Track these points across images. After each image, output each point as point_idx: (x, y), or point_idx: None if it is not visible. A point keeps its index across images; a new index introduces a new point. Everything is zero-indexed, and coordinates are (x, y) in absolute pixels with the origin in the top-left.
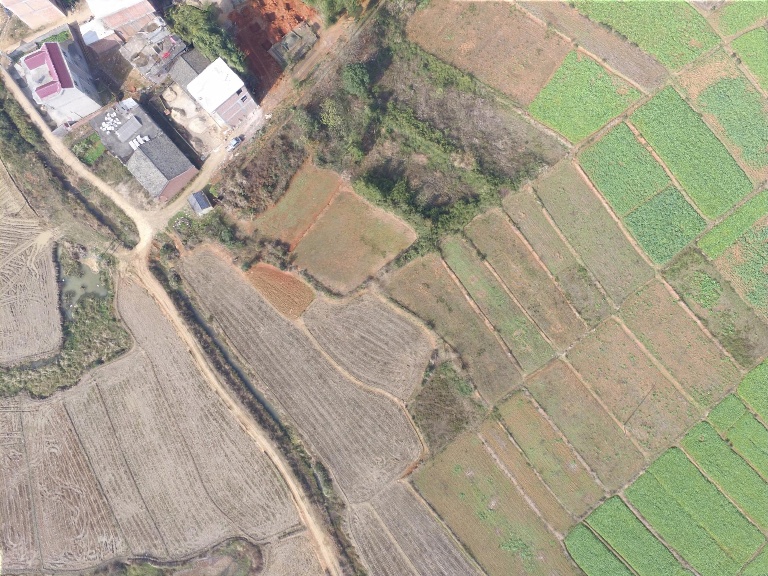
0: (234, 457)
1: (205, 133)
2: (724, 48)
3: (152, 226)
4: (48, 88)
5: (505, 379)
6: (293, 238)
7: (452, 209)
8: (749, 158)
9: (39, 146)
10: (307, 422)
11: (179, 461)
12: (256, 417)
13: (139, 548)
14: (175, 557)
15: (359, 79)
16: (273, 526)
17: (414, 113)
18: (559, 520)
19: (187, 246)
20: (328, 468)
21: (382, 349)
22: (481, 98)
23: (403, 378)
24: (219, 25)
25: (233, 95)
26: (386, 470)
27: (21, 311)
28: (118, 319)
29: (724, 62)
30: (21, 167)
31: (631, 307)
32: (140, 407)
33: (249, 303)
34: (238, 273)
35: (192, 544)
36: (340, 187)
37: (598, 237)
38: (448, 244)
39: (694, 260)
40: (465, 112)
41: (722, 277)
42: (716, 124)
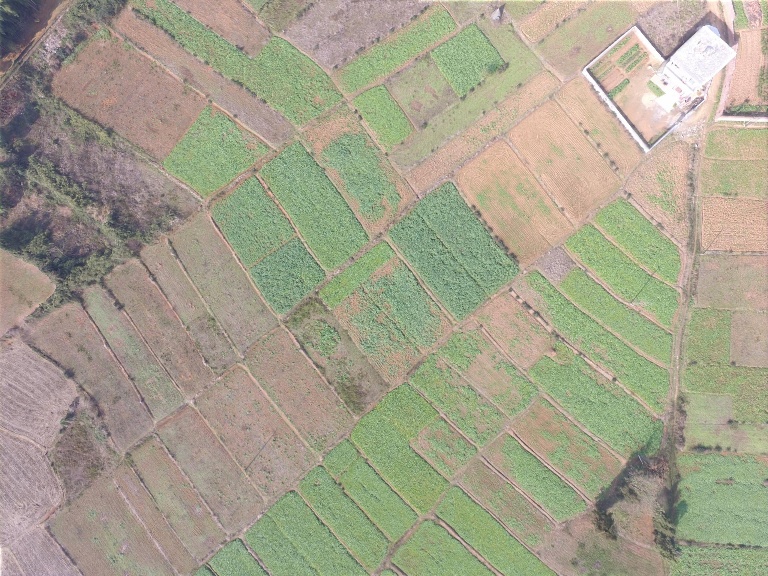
0: None
1: None
2: (348, 105)
3: None
4: None
5: (138, 426)
6: None
7: (87, 261)
8: (365, 211)
9: None
10: None
11: None
12: None
13: None
14: None
15: None
16: None
17: (57, 166)
18: (183, 563)
19: None
20: None
21: (28, 397)
22: (121, 152)
23: (46, 425)
24: None
25: None
26: (27, 516)
27: None
28: None
29: (348, 118)
30: None
31: (257, 355)
32: None
33: None
34: None
35: None
36: None
37: (227, 287)
38: (90, 294)
39: (316, 310)
40: (105, 166)
41: (341, 326)
42: (337, 178)
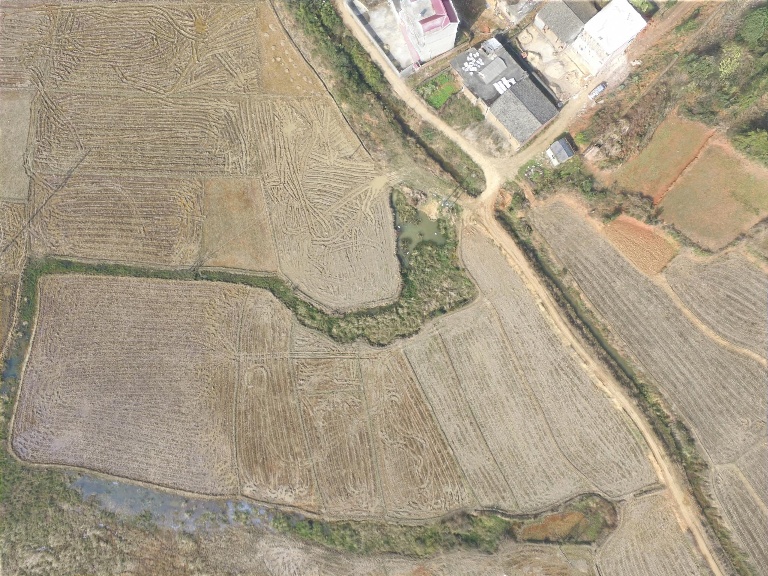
0: (587, 413)
1: (563, 79)
2: None
3: (501, 174)
4: (434, 22)
5: None
6: (656, 191)
7: None
8: None
9: (384, 86)
10: (667, 380)
11: (527, 415)
12: (614, 373)
13: (487, 500)
14: (525, 510)
15: (767, 24)
16: (629, 484)
17: None
18: None
19: (540, 196)
20: (690, 428)
21: (749, 309)
22: None
23: None
24: None
25: (633, 36)
26: (752, 432)
27: (357, 256)
28: (462, 268)
29: None
30: (359, 108)
31: None
32: (486, 359)
33: (604, 257)
34: (592, 226)
35: (543, 498)
36: (710, 140)
37: None
38: None
39: None
40: None
41: None
42: None
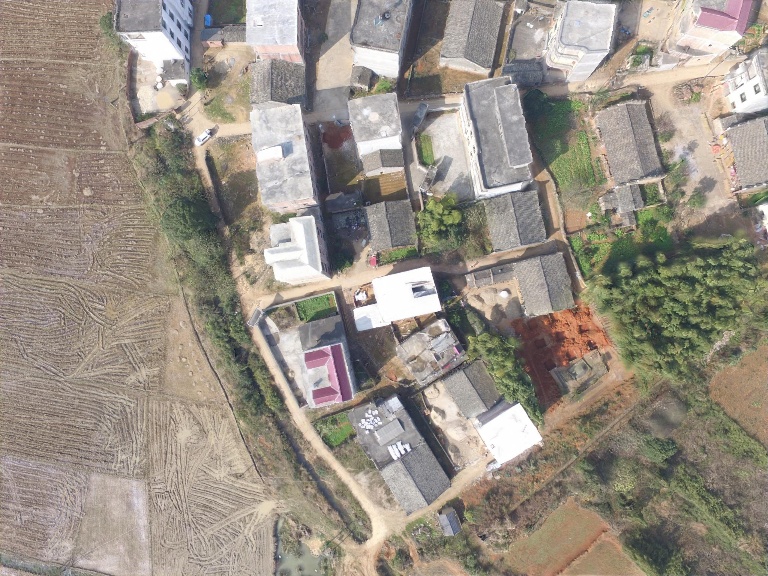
0: None
1: (464, 442)
2: None
3: (388, 526)
4: (327, 397)
5: None
6: None
7: None
8: None
9: (282, 416)
10: None
11: None
12: None
13: None
14: None
15: None
16: None
17: (704, 481)
18: None
19: (424, 559)
20: None
21: None
22: None
23: None
24: (500, 330)
25: None
26: None
27: None
28: None
29: None
30: (256, 430)
31: None
32: None
33: None
34: None
35: None
36: (603, 535)
37: None
38: None
39: None
40: (760, 491)
41: None
42: None
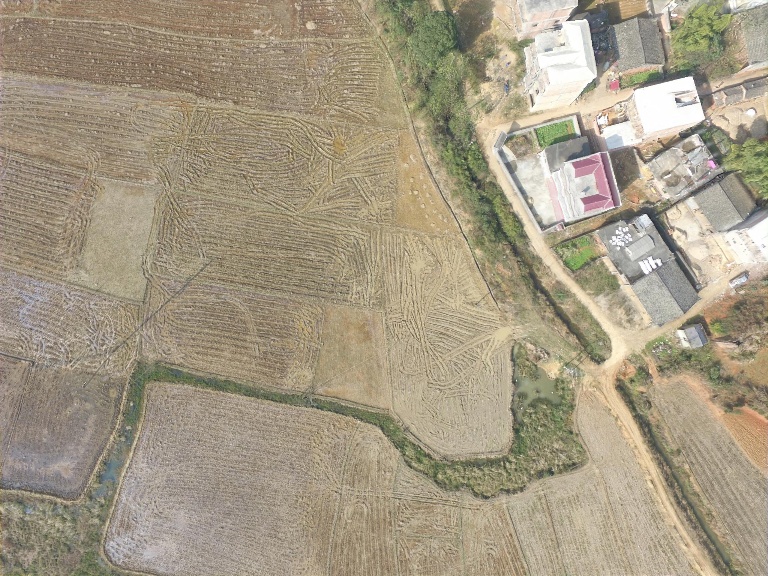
0: None
1: (705, 261)
2: None
3: (628, 345)
4: (597, 203)
5: None
6: None
7: None
8: None
9: (523, 241)
10: (763, 573)
11: None
12: (712, 559)
13: None
14: None
15: None
16: None
17: None
18: None
19: (665, 374)
20: None
21: None
22: None
23: None
24: None
25: None
26: None
27: (472, 405)
28: (576, 433)
29: None
30: (493, 257)
31: None
32: (587, 525)
33: (719, 443)
34: (712, 410)
35: None
36: None
37: None
38: None
39: None
40: None
41: None
42: None
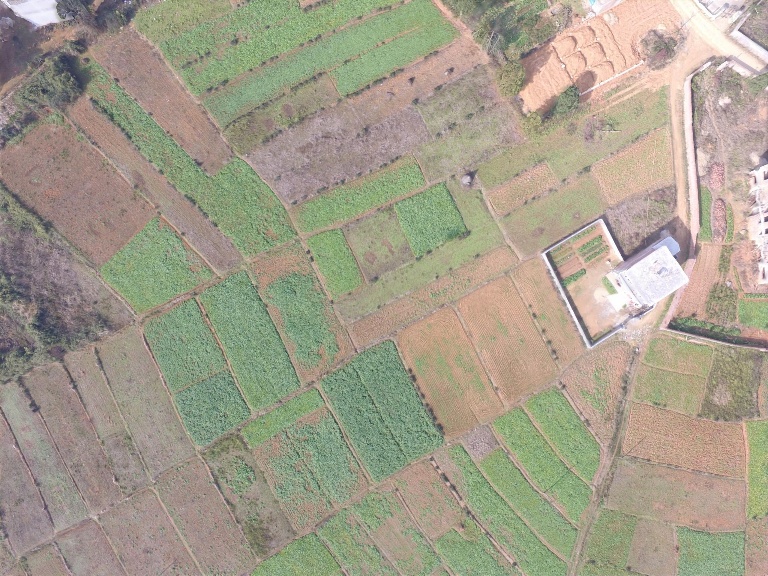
0: None
1: None
2: (301, 243)
3: None
4: None
5: (37, 532)
6: None
7: (6, 359)
8: (301, 357)
9: None
10: None
11: None
12: None
13: None
14: None
15: None
16: None
17: None
18: None
19: None
20: None
21: None
22: (58, 249)
23: None
24: None
25: None
26: None
27: None
28: None
29: (299, 257)
30: None
31: (169, 481)
32: None
33: None
34: None
35: None
36: None
37: (149, 408)
38: (5, 390)
39: (236, 445)
40: (39, 261)
41: (258, 466)
42: (278, 318)
